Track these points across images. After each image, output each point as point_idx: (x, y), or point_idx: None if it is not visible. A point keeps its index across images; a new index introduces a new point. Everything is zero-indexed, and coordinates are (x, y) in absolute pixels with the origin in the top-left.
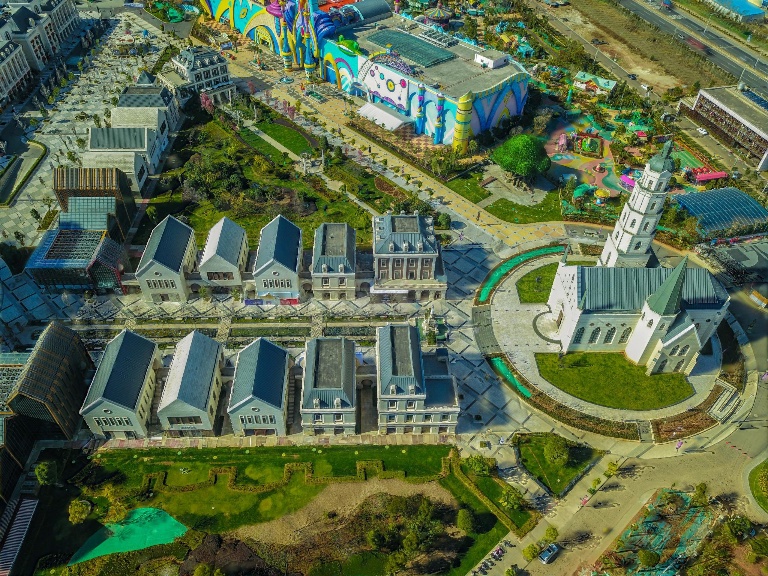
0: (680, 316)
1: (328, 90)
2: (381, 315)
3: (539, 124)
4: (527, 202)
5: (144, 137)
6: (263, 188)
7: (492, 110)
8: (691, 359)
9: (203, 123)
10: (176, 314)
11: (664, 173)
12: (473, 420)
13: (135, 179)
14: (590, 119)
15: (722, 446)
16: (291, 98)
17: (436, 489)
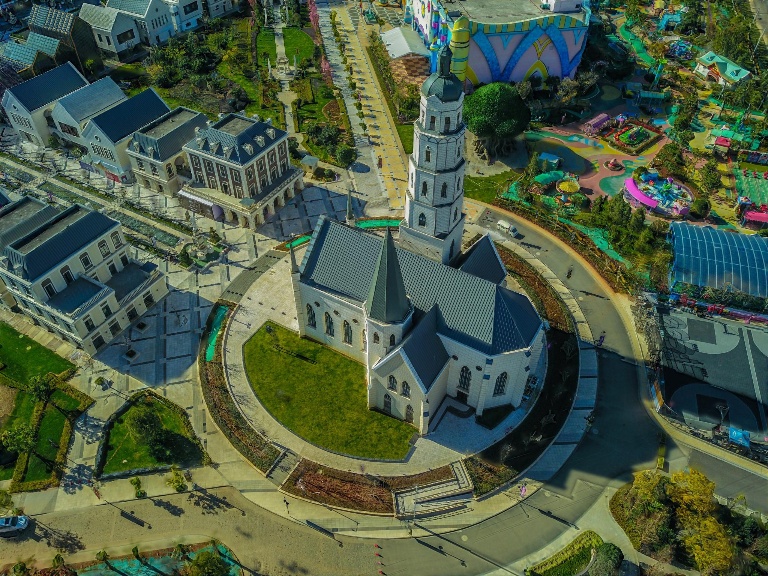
0: (408, 334)
1: (391, 15)
2: (175, 220)
3: (562, 87)
4: (470, 171)
5: (148, 4)
6: (218, 79)
7: (512, 57)
8: (420, 410)
9: (242, 17)
10: (25, 155)
11: (432, 99)
12: (124, 353)
13: (112, 38)
14: (673, 110)
15: (364, 545)
16: (346, 14)
17: (7, 397)
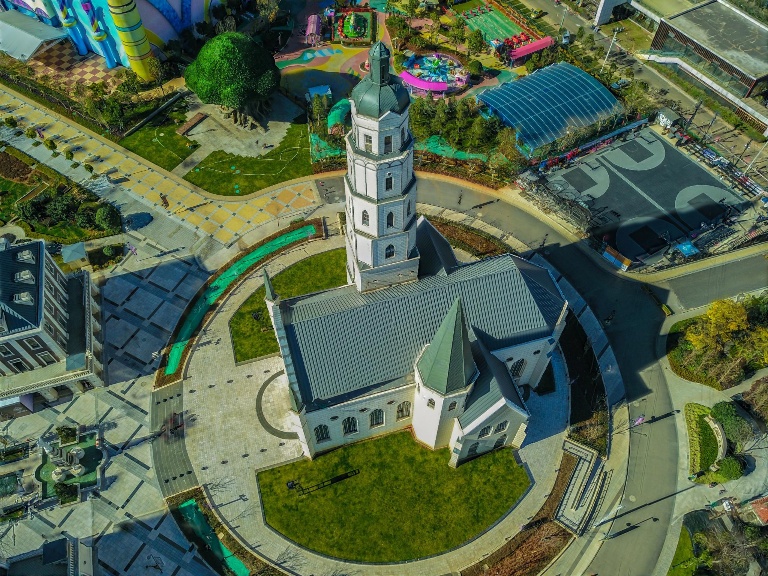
0: (481, 377)
1: None
2: None
3: (264, 6)
4: (256, 150)
5: None
6: None
7: None
8: (517, 430)
9: None
10: None
11: (385, 118)
12: None
13: None
14: None
15: None
16: None
17: None
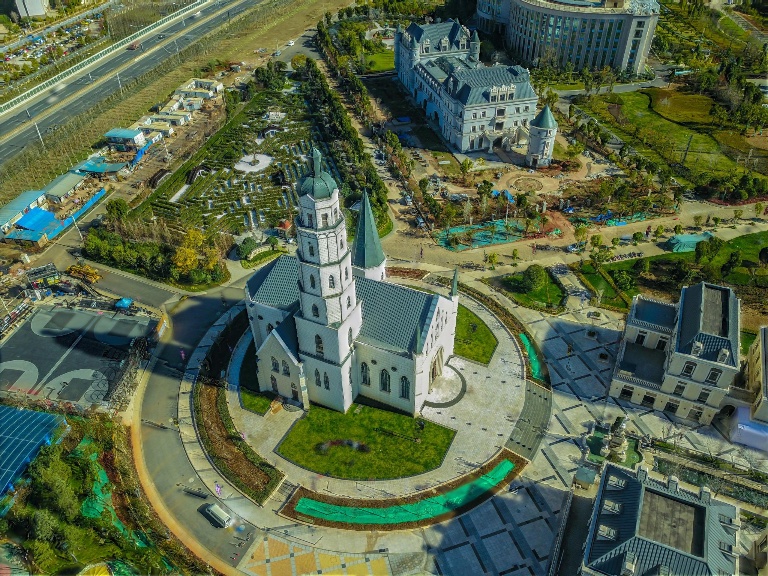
0: None
1: None
2: None
3: None
4: None
5: None
6: None
7: None
8: None
9: None
10: None
11: None
12: (598, 335)
13: None
14: None
15: None
16: None
17: None
